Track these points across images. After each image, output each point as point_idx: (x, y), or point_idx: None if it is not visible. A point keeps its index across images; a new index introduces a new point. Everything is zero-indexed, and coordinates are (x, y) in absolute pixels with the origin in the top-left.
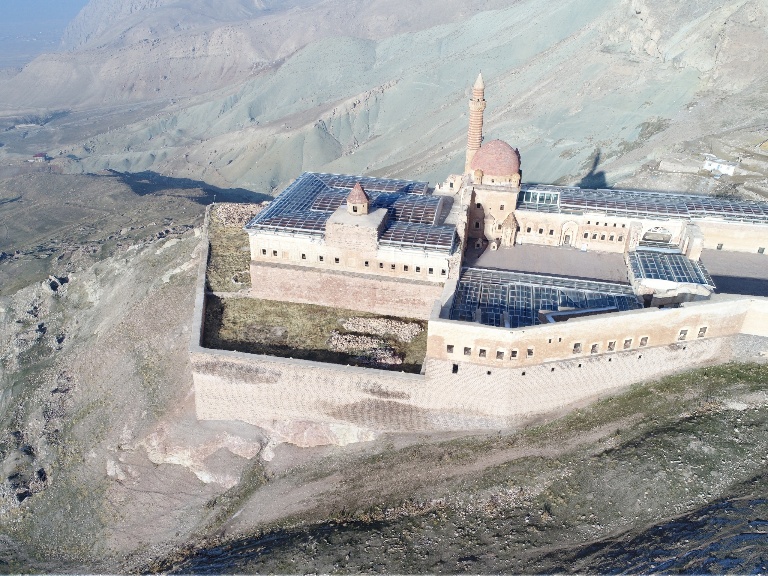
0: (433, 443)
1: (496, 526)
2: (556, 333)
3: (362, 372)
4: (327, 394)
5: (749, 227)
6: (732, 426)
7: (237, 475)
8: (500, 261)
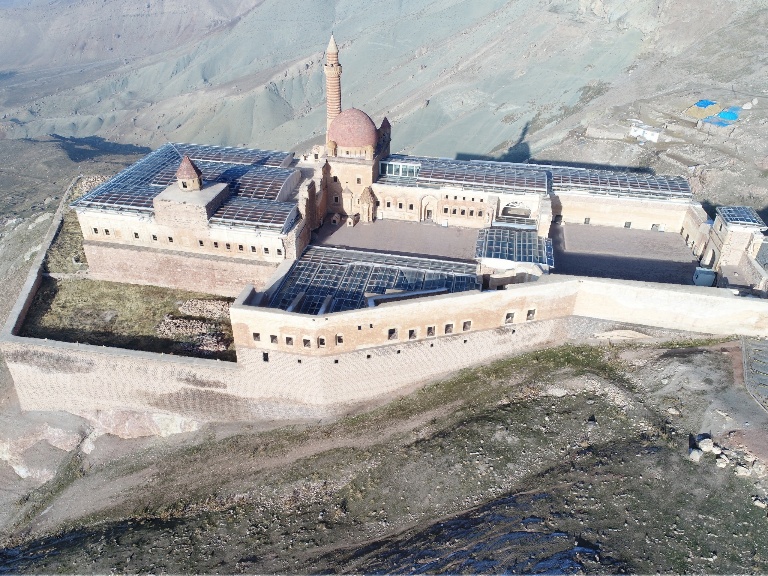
0: (253, 433)
1: (288, 523)
2: (365, 319)
3: (175, 361)
4: (144, 383)
5: (614, 201)
6: (544, 414)
7: (54, 469)
8: (353, 238)
